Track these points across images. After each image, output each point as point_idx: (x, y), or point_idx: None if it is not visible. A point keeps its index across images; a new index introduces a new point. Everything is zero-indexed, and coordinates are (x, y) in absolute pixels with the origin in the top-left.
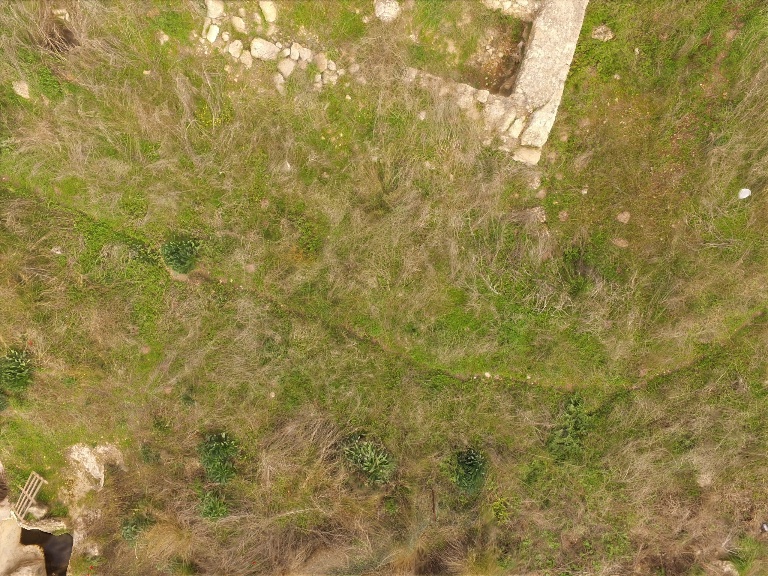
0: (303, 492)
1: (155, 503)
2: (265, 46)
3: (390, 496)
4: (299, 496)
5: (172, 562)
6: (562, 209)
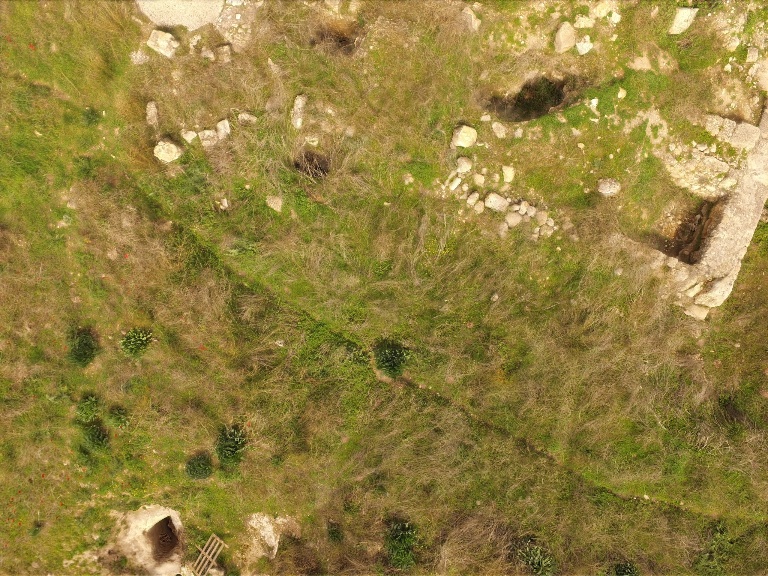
0: None
1: None
2: (499, 200)
3: None
4: None
5: None
6: (717, 357)
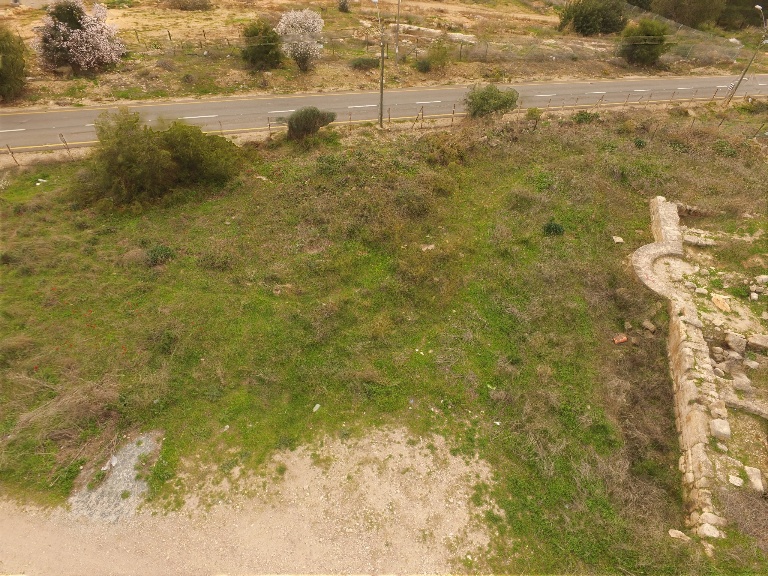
0: None
1: None
2: None
3: None
4: None
5: None
6: None
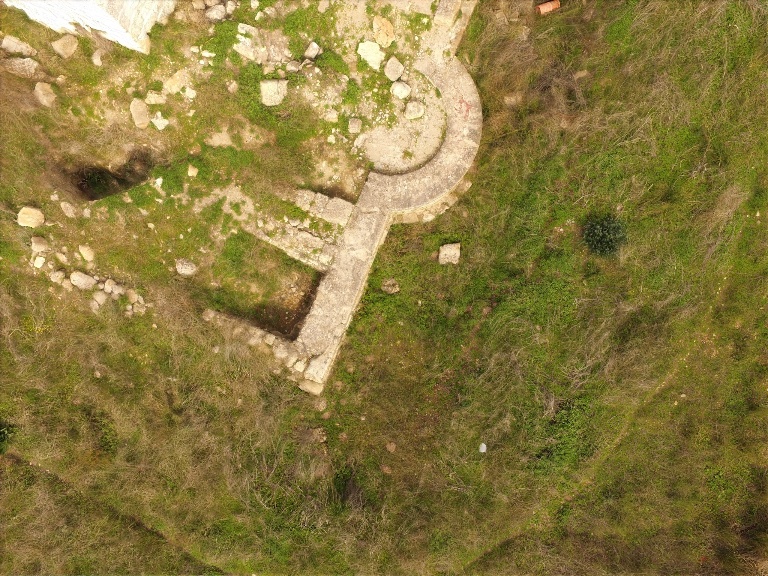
0: None
1: None
2: (83, 279)
3: None
4: None
5: None
6: (342, 431)
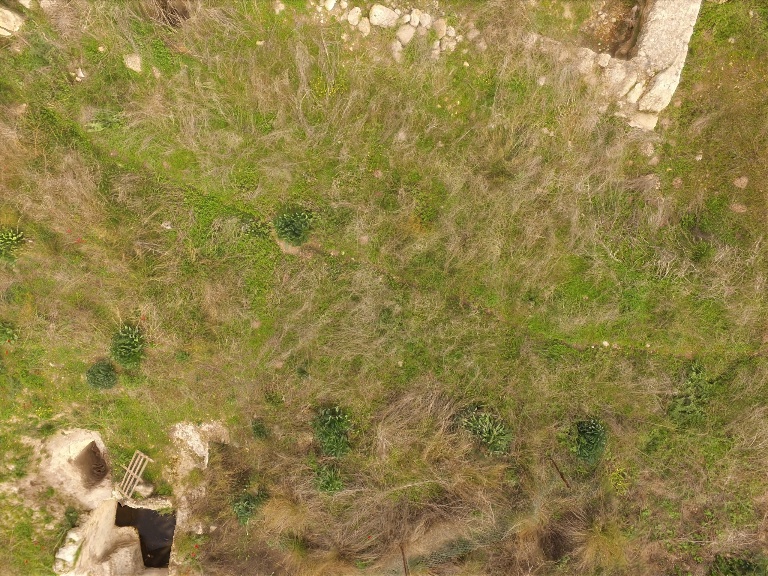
0: (421, 464)
1: (268, 479)
2: (385, 12)
3: (511, 467)
4: (417, 468)
5: (284, 538)
6: (676, 176)
